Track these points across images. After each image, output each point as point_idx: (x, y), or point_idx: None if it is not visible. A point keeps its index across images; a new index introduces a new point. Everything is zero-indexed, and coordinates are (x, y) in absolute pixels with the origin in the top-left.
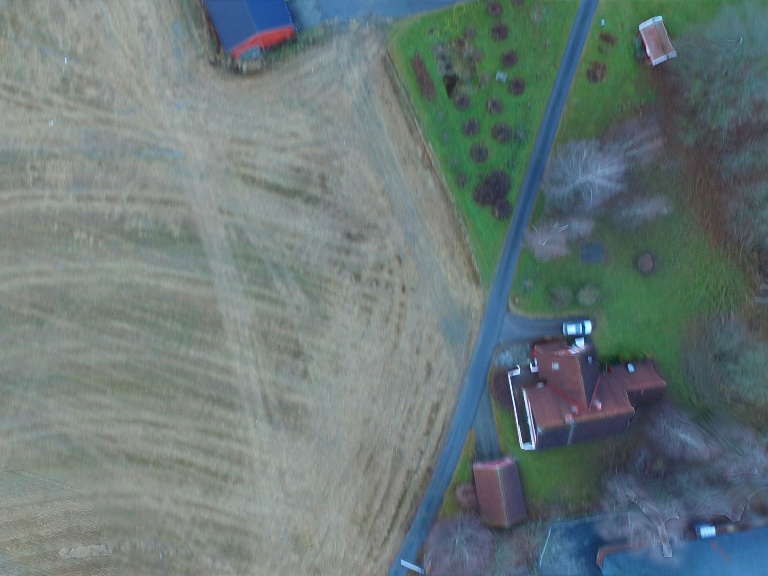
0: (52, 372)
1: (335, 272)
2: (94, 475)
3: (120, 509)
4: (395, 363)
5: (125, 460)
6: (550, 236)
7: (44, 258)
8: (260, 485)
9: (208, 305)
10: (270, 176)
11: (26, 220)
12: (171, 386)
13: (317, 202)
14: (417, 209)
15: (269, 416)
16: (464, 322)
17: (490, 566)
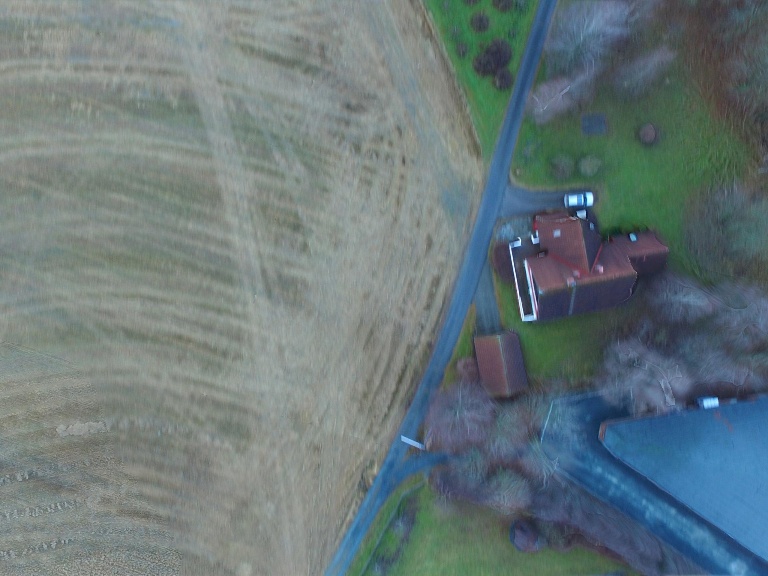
0: (50, 245)
1: (335, 143)
2: (92, 351)
3: (118, 386)
4: (395, 236)
5: (123, 336)
6: (551, 100)
7: (41, 129)
8: (259, 361)
9: (207, 177)
10: (269, 45)
11: (23, 90)
12: (169, 260)
13: (316, 72)
14: (417, 80)
15: (268, 291)
16: (465, 195)
17: (491, 433)
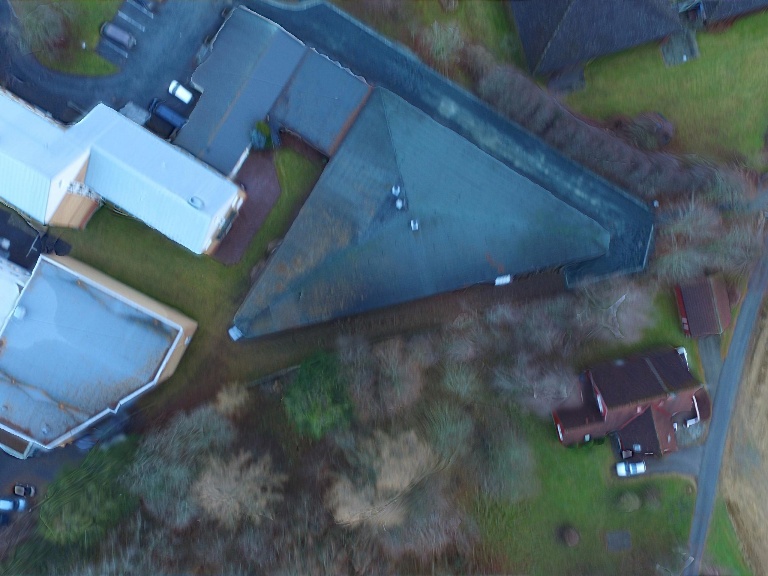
0: None
1: None
2: None
3: None
4: None
5: None
6: None
7: None
8: None
9: None
10: None
11: None
12: None
13: None
14: None
15: None
16: (739, 464)
17: None
